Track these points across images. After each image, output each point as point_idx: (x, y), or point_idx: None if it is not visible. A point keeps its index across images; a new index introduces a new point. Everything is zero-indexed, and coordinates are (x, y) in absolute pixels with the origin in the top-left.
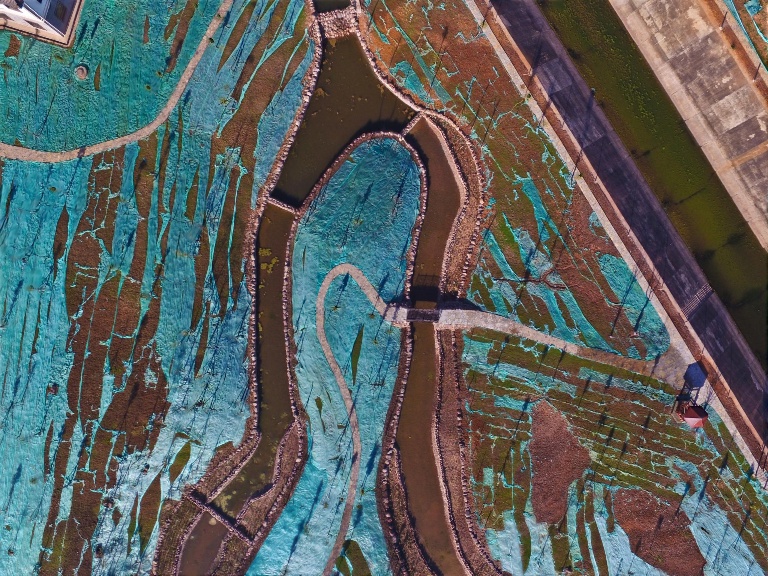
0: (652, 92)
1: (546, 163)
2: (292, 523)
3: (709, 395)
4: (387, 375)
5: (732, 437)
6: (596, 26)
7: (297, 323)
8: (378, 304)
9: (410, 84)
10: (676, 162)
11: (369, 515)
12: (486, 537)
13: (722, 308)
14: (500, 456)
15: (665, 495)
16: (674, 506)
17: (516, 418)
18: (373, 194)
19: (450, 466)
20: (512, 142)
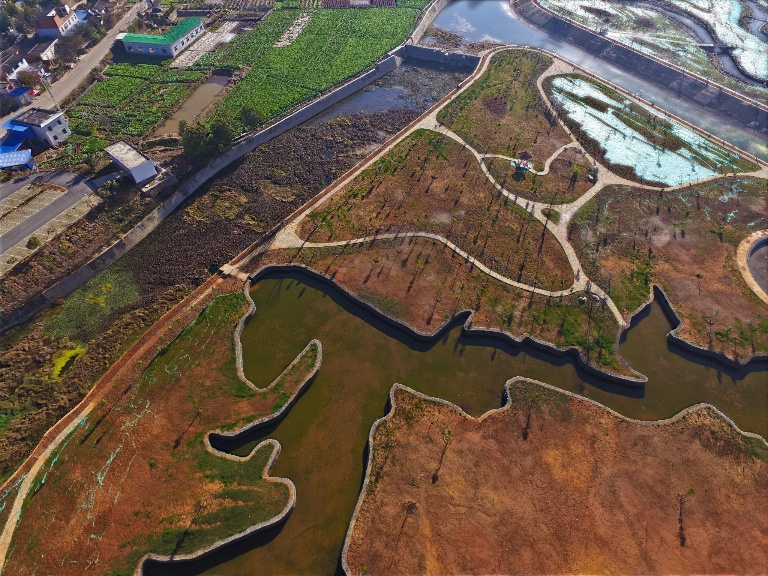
0: None
1: None
2: (734, 16)
3: None
4: None
5: None
6: None
7: None
8: None
9: None
10: None
11: None
12: None
13: (589, 54)
14: None
15: (602, 17)
16: None
17: None
18: None
19: None
20: None
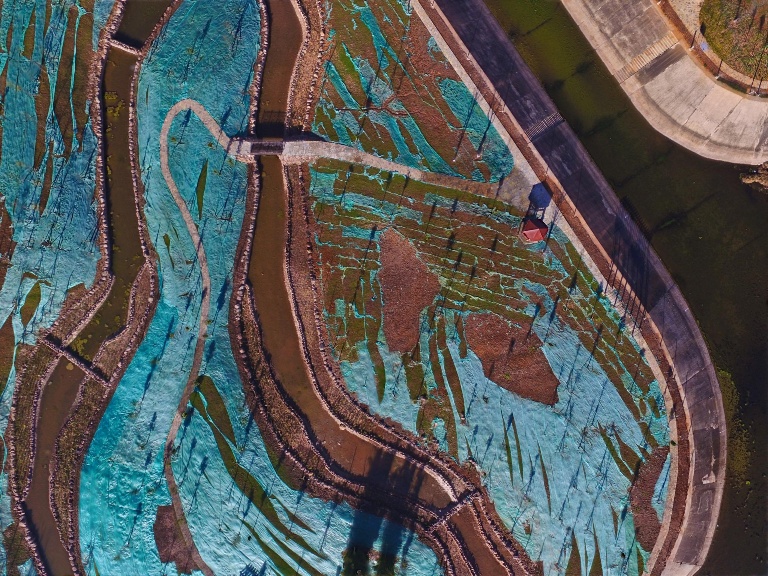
0: None
1: None
2: (145, 361)
3: (555, 215)
4: (234, 210)
5: (580, 256)
6: None
7: (143, 162)
8: (221, 138)
9: None
10: None
11: (222, 351)
12: (341, 369)
13: (573, 136)
14: (350, 287)
15: (516, 317)
16: (525, 328)
17: (364, 247)
18: (212, 29)
19: (303, 301)
20: None
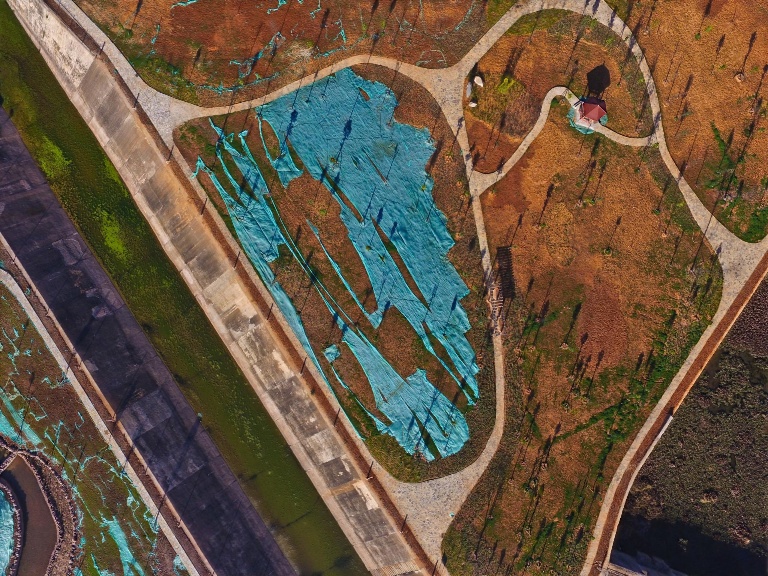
0: (258, 417)
1: (131, 507)
2: None
3: None
4: None
5: None
6: (202, 352)
7: None
8: None
9: (1, 427)
10: (282, 486)
11: None
12: None
13: None
14: None
15: None
16: None
17: None
18: None
19: None
20: (99, 485)
